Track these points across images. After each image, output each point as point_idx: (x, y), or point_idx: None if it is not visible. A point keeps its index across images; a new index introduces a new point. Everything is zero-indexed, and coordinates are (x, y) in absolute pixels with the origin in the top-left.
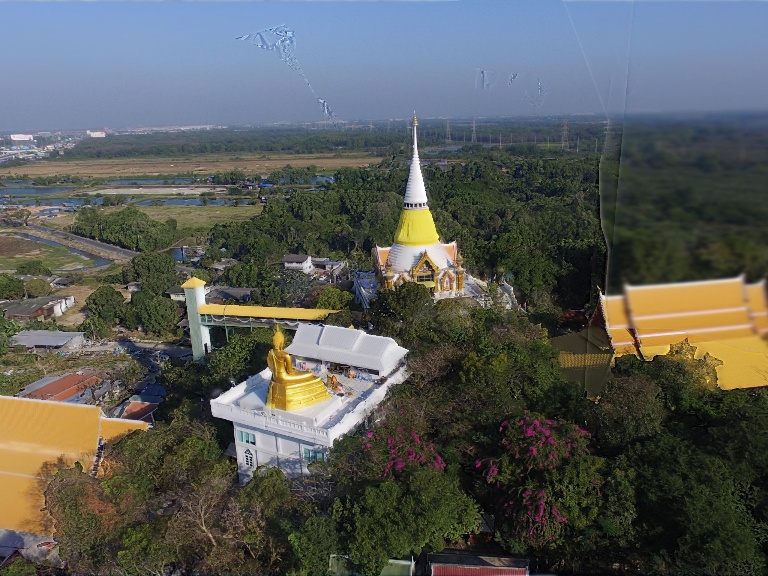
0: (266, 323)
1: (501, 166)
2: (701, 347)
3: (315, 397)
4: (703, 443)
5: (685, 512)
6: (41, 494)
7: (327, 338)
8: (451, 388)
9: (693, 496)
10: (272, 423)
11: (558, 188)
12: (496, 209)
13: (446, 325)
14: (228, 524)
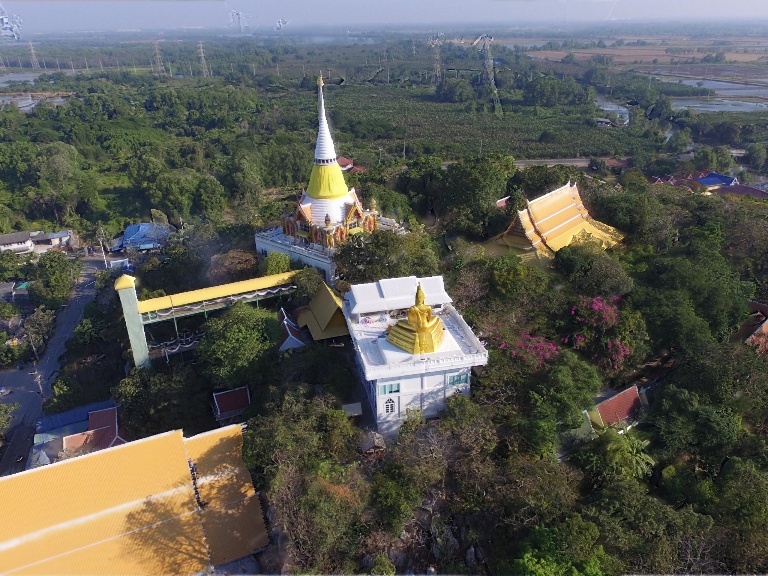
0: (221, 303)
1: (128, 99)
2: (569, 234)
3: (441, 335)
4: (659, 285)
5: (680, 323)
6: (142, 546)
7: (389, 290)
8: (500, 300)
9: (681, 314)
10: (433, 365)
11: (216, 119)
12: (178, 148)
13: (428, 258)
14: (472, 444)
